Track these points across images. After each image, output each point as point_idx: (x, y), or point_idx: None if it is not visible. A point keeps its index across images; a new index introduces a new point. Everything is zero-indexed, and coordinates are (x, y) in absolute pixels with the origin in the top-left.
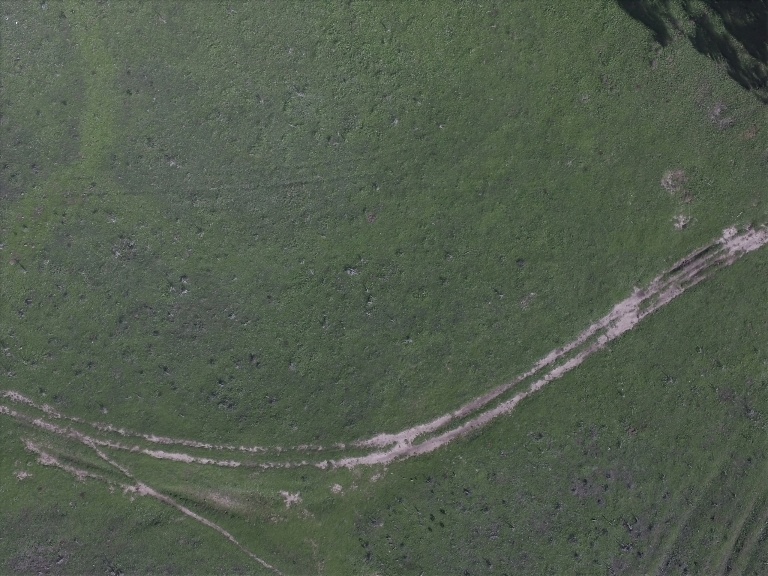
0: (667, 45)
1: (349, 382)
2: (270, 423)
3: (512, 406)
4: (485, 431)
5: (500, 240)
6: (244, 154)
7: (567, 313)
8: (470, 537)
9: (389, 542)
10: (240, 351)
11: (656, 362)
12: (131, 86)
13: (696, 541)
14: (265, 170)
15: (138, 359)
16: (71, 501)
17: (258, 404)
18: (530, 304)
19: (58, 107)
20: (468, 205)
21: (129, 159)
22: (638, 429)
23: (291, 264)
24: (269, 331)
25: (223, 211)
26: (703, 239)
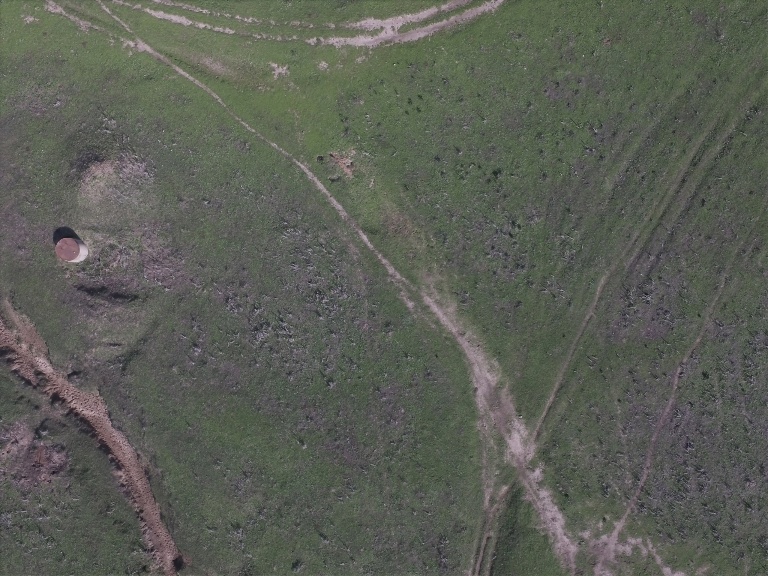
0: None
1: None
2: None
3: (496, 6)
4: (468, 26)
5: None
6: None
7: None
8: (444, 125)
9: (367, 120)
10: None
11: None
12: None
13: (656, 152)
14: None
15: None
16: (73, 49)
17: None
18: None
19: None
20: None
21: None
22: (612, 40)
23: None
24: None
25: None
26: None
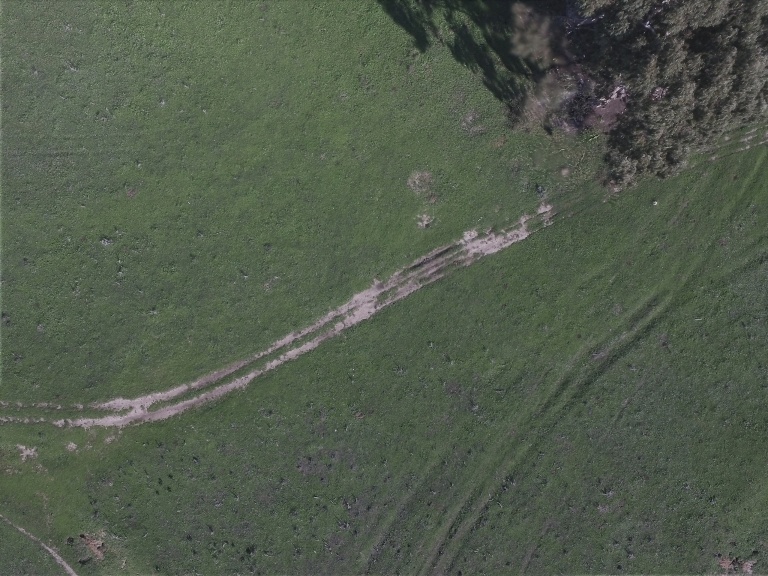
0: (425, 52)
1: (93, 347)
2: (13, 379)
3: (246, 382)
4: (218, 404)
5: (250, 224)
6: (15, 121)
7: (308, 298)
8: (196, 503)
9: (117, 502)
10: None
11: (389, 352)
12: None
13: (411, 525)
14: (33, 138)
15: None
16: None
17: (4, 360)
18: (273, 287)
19: None
20: (223, 188)
21: None
22: (365, 414)
23: (50, 230)
24: (22, 292)
25: None
26: (444, 239)
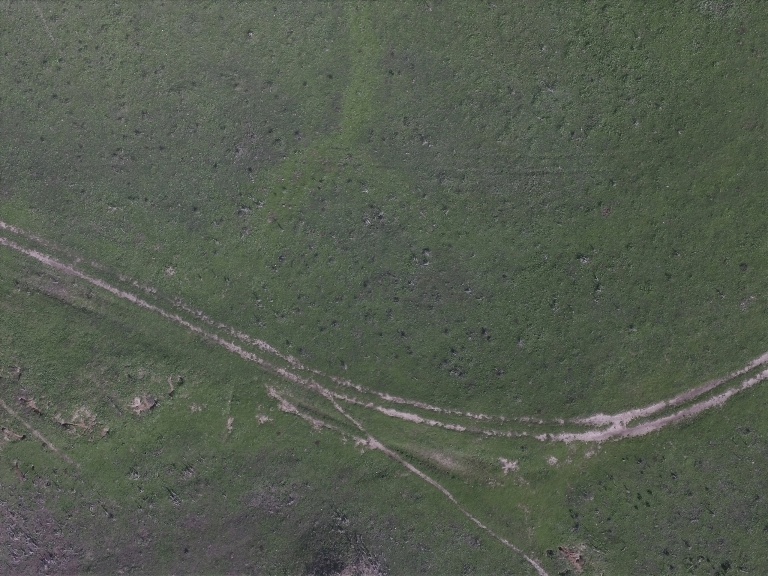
0: None
1: (573, 363)
2: (496, 394)
3: (724, 400)
4: (696, 421)
5: (726, 244)
6: (492, 140)
7: None
8: (672, 519)
9: (597, 516)
10: (473, 324)
11: None
12: (393, 67)
13: None
14: (510, 157)
15: (379, 322)
16: (306, 448)
17: (486, 375)
18: (749, 307)
19: (324, 80)
20: (699, 208)
21: (385, 135)
22: None
23: (527, 247)
24: (501, 308)
25: (468, 192)
26: None
